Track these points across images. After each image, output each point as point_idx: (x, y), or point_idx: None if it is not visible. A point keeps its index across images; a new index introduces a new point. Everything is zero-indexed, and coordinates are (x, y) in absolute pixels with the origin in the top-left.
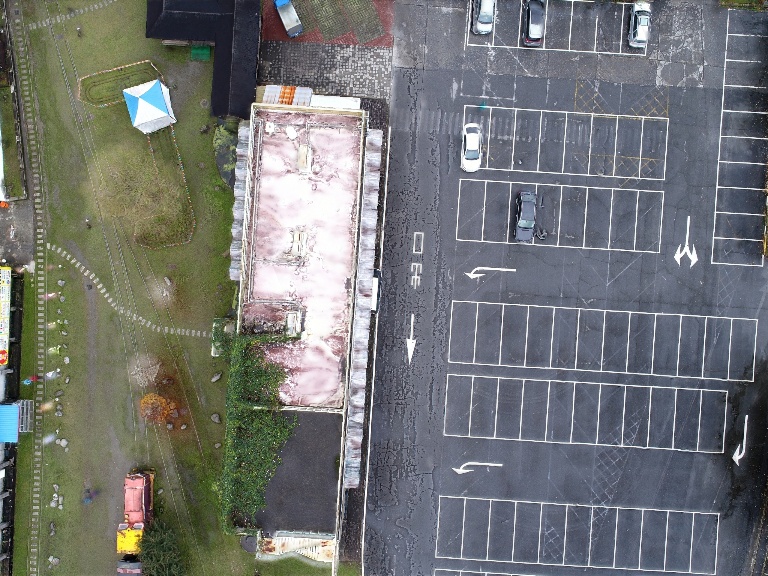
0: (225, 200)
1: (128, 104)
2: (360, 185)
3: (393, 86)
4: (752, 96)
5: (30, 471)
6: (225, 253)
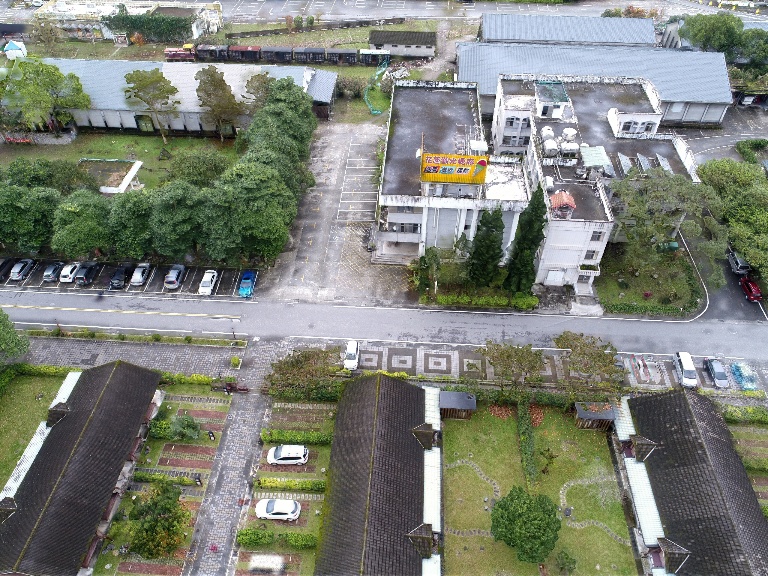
0: None
1: (10, 49)
2: (80, 3)
3: None
4: None
5: None
6: None
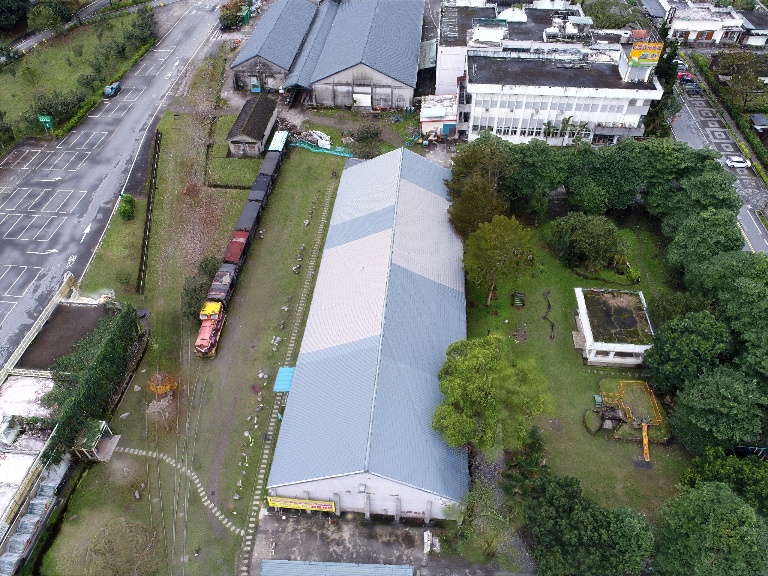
0: (51, 571)
1: None
2: None
3: None
4: None
5: (293, 360)
6: (73, 518)
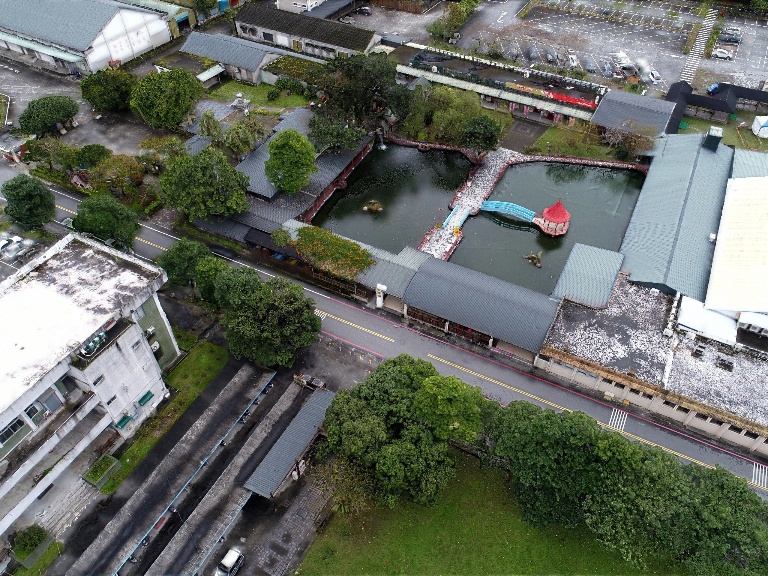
0: None
1: None
2: None
3: (753, 78)
4: (760, 22)
5: None
6: None
